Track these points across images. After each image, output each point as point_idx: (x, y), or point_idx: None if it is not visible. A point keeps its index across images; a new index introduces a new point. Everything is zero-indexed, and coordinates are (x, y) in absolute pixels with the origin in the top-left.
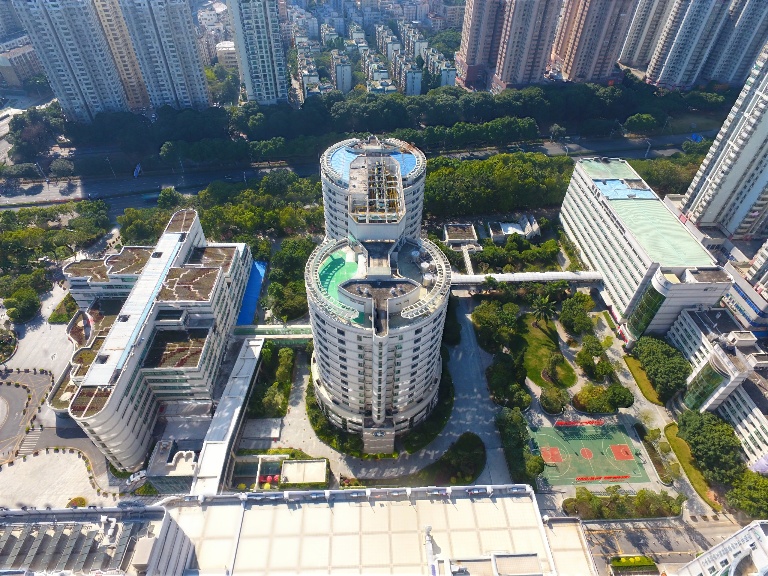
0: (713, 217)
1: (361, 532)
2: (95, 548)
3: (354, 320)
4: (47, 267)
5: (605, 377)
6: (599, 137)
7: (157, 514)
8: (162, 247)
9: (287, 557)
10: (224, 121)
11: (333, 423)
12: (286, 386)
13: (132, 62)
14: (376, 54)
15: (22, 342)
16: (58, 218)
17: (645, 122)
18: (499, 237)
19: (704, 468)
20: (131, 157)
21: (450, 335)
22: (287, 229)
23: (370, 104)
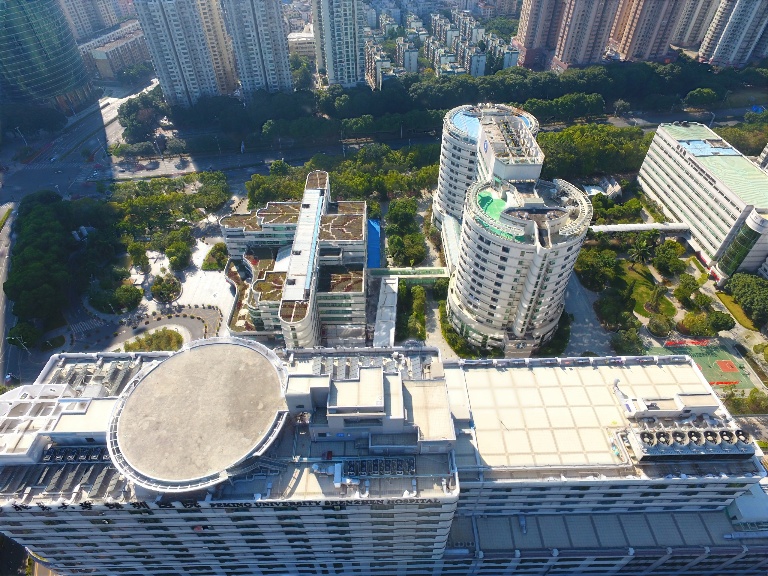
0: None
1: (561, 385)
2: None
3: (517, 239)
4: None
5: (702, 309)
6: (660, 112)
7: (431, 353)
8: (308, 200)
9: (509, 400)
10: (313, 102)
11: (472, 343)
12: (421, 317)
13: (220, 52)
14: (439, 40)
15: (185, 285)
16: (184, 187)
17: (706, 96)
18: None
19: None
20: None
21: None
22: (389, 194)
23: (444, 84)
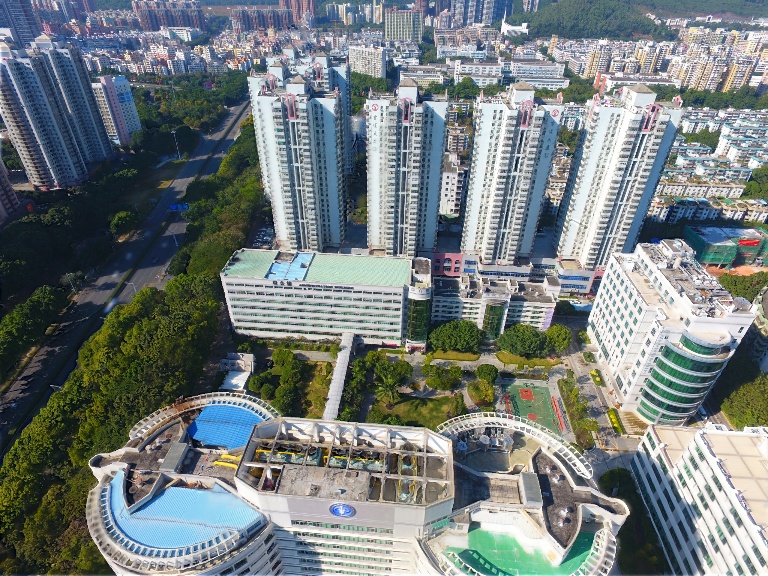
0: (321, 242)
1: None
2: None
3: None
4: None
5: None
6: (105, 257)
7: None
8: None
9: None
10: None
11: None
12: None
13: None
14: None
15: None
16: None
17: (129, 219)
18: None
19: (541, 353)
20: None
21: None
22: None
23: None
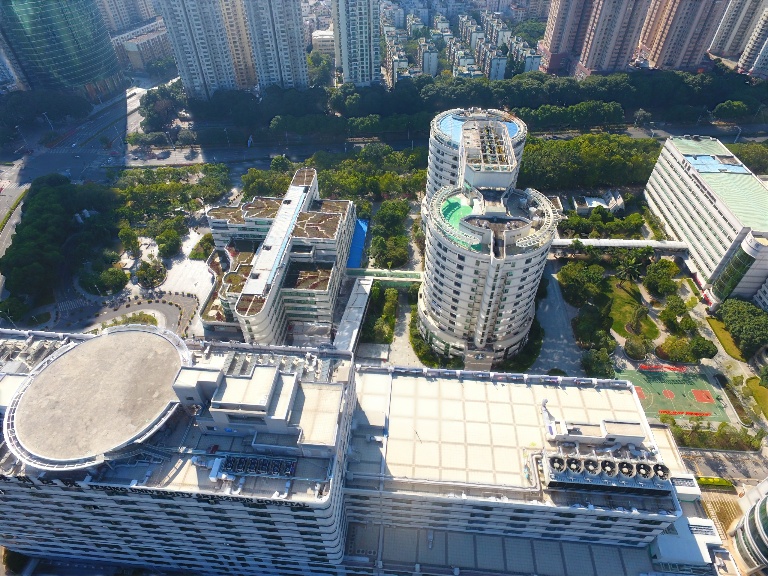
0: None
1: (488, 401)
2: (305, 372)
3: (473, 248)
4: None
5: (688, 334)
6: (685, 124)
7: (345, 356)
8: (290, 196)
9: (430, 411)
10: (324, 100)
11: (435, 350)
12: (391, 320)
13: (242, 47)
14: (462, 42)
15: (170, 272)
16: (187, 177)
17: (736, 109)
18: (583, 209)
19: None
20: (241, 131)
21: (538, 288)
22: (384, 194)
23: (458, 87)
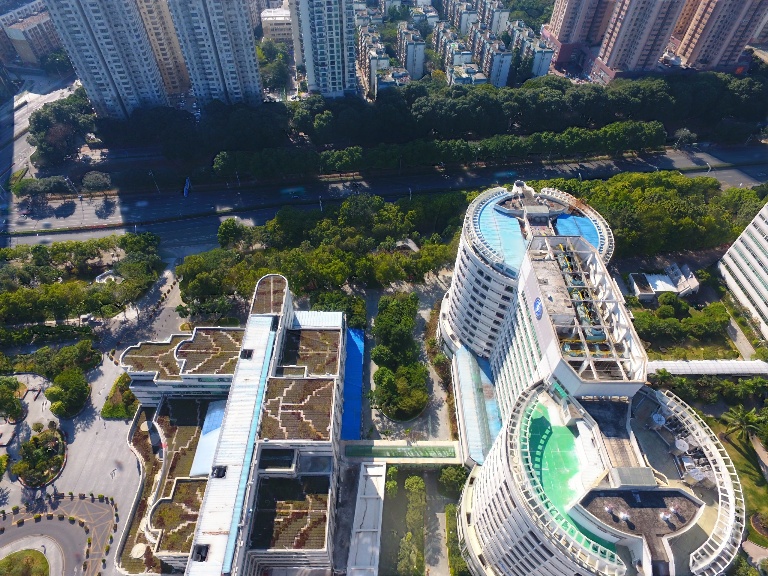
0: None
1: None
2: None
3: None
4: (92, 328)
5: None
6: (732, 143)
7: None
8: (251, 340)
9: None
10: (285, 121)
11: None
12: (418, 532)
13: (168, 39)
14: (452, 28)
15: (72, 448)
16: (98, 255)
17: None
18: (647, 295)
19: None
20: (174, 163)
21: None
22: None
23: (458, 100)
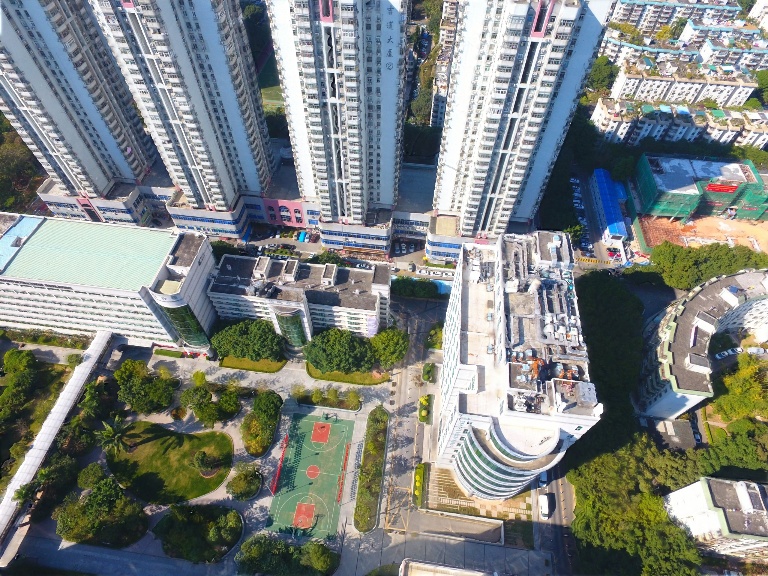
0: (103, 179)
1: None
2: None
3: None
4: None
5: None
6: None
7: None
8: None
9: None
10: None
11: None
12: None
13: None
14: None
15: None
16: None
17: None
18: None
19: (357, 370)
20: None
21: None
22: None
23: None
